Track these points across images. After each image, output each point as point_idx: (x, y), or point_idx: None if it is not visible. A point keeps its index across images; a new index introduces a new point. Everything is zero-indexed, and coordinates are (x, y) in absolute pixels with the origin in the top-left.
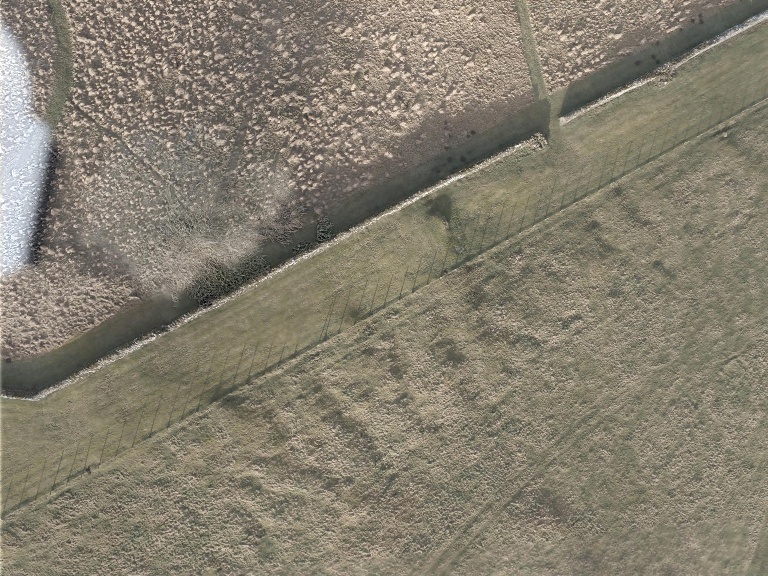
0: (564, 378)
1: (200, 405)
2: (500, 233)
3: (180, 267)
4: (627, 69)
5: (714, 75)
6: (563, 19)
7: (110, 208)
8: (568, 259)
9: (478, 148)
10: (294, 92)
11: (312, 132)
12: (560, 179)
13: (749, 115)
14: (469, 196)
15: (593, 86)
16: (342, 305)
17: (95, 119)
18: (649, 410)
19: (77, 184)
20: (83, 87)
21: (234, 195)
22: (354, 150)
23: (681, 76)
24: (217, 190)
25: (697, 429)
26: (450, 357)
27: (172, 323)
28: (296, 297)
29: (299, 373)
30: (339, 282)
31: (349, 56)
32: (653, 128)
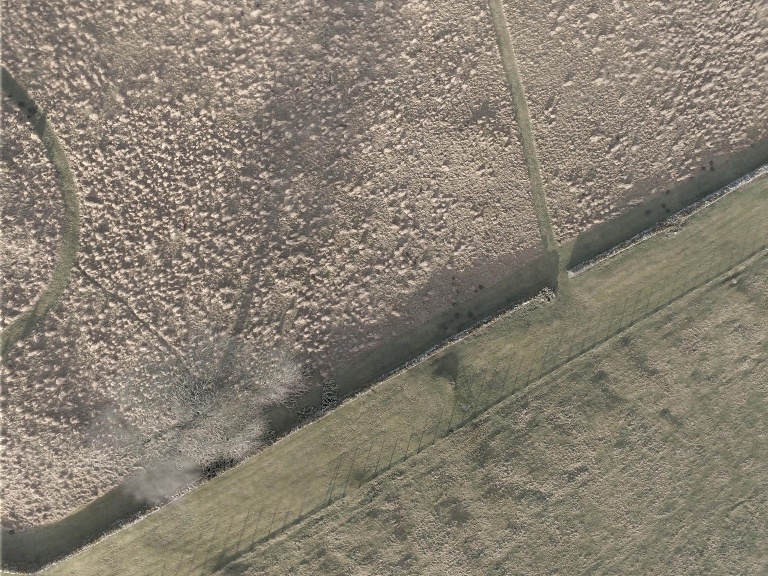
0: (569, 531)
1: (203, 574)
2: (507, 387)
3: (185, 435)
4: (637, 219)
5: (724, 221)
6: (573, 170)
7: (115, 375)
8: (575, 411)
9: (486, 303)
10: (301, 254)
11: (319, 293)
12: (568, 331)
13: (759, 260)
14: (476, 353)
15: (602, 237)
16: (347, 468)
17: (101, 284)
18: (654, 559)
19: (82, 351)
20: (90, 251)
21: (240, 359)
22: (361, 309)
23: (691, 225)
24: (223, 355)
25: (702, 575)
26: (455, 516)
27: (176, 494)
28: (301, 462)
29: (303, 538)
30: (344, 444)
31: (357, 215)
32: (662, 277)
